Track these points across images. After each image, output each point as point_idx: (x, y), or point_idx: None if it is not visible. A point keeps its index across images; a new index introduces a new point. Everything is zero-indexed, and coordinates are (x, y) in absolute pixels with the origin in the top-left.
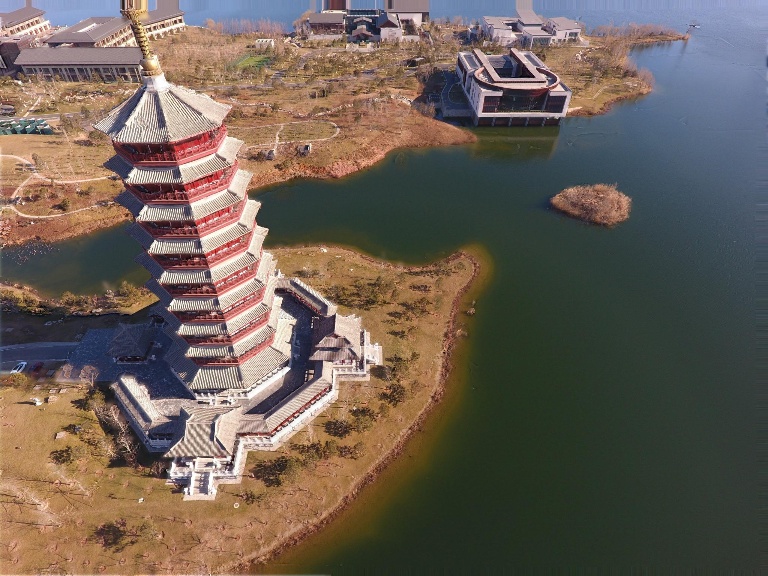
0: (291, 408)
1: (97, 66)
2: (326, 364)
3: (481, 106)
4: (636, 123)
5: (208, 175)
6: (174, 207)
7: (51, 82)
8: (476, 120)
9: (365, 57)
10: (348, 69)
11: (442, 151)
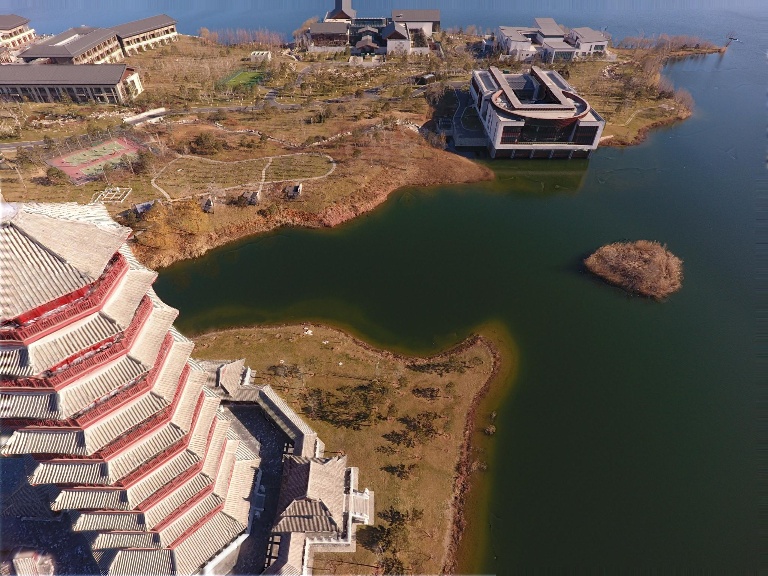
0: None
1: (70, 86)
2: (295, 537)
3: (499, 137)
4: (676, 155)
5: (84, 349)
6: (35, 393)
7: (20, 103)
8: (493, 152)
9: (369, 72)
10: (350, 87)
11: (454, 191)
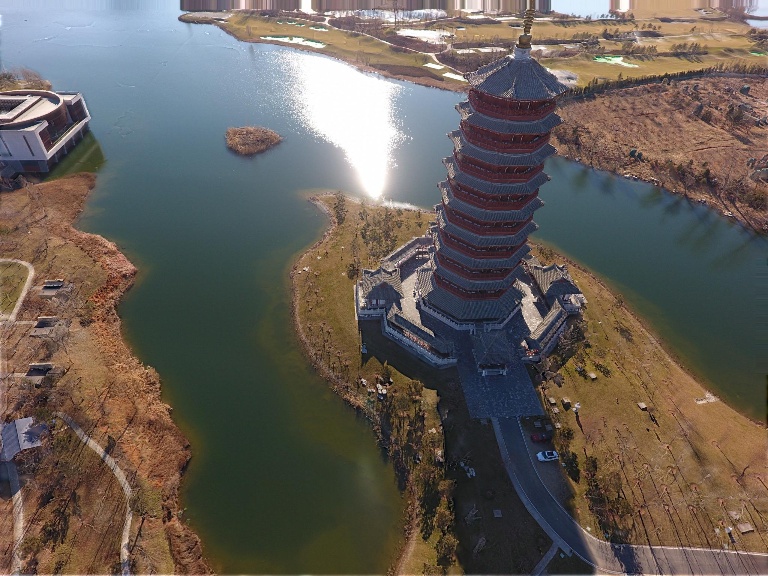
0: None
1: None
2: None
3: (42, 146)
4: (109, 102)
5: None
6: None
7: None
8: (45, 165)
9: None
10: None
11: (101, 198)
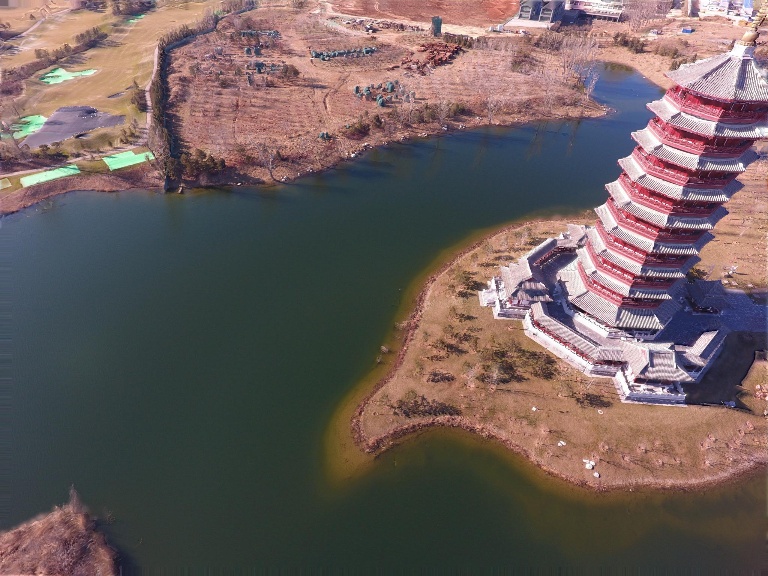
0: (541, 246)
1: None
2: None
3: None
4: None
5: None
6: None
7: None
8: None
9: None
10: None
11: None
